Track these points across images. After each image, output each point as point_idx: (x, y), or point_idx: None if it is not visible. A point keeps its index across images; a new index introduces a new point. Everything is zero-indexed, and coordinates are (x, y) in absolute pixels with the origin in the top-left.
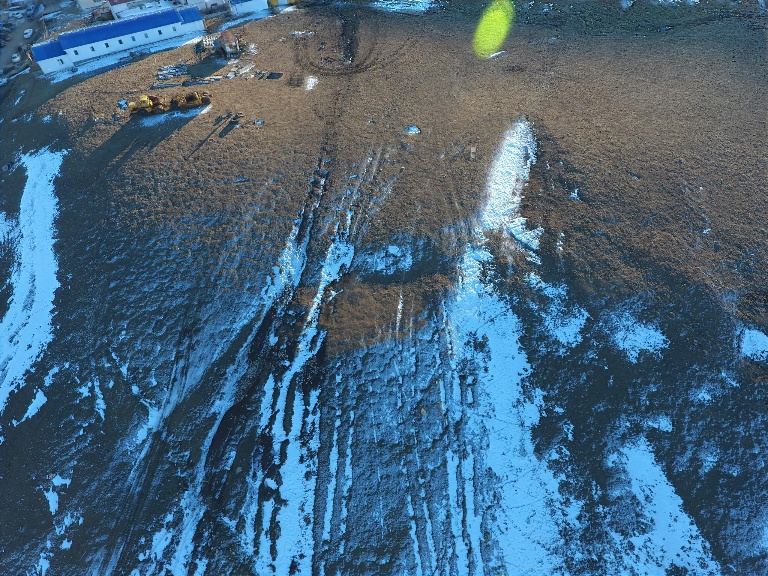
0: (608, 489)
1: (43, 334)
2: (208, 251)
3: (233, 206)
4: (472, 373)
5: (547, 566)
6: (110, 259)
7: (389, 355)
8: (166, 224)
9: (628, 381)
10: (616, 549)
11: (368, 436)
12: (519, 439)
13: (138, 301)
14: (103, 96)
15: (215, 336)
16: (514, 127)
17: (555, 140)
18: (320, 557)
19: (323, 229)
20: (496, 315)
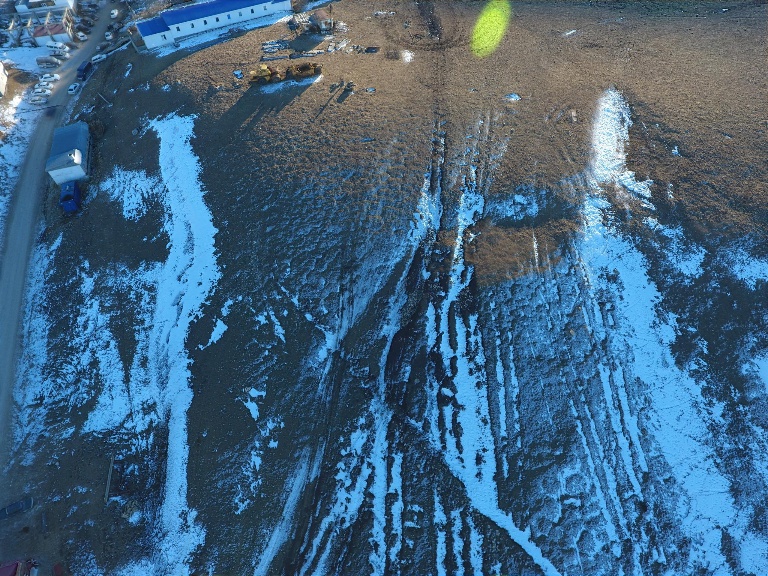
0: (745, 392)
1: (211, 273)
2: (352, 200)
3: (366, 162)
4: (609, 300)
5: (700, 454)
6: (262, 207)
7: (534, 286)
8: (308, 177)
9: (750, 305)
10: (759, 439)
11: (527, 352)
12: (660, 353)
13: (296, 243)
14: (217, 67)
15: (373, 272)
16: (606, 95)
17: (647, 105)
18: (501, 450)
19: (452, 181)
20: (623, 252)
